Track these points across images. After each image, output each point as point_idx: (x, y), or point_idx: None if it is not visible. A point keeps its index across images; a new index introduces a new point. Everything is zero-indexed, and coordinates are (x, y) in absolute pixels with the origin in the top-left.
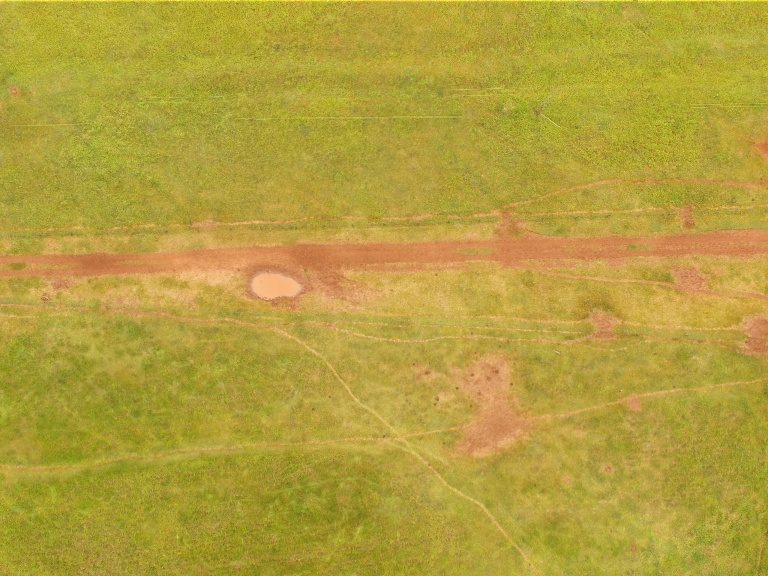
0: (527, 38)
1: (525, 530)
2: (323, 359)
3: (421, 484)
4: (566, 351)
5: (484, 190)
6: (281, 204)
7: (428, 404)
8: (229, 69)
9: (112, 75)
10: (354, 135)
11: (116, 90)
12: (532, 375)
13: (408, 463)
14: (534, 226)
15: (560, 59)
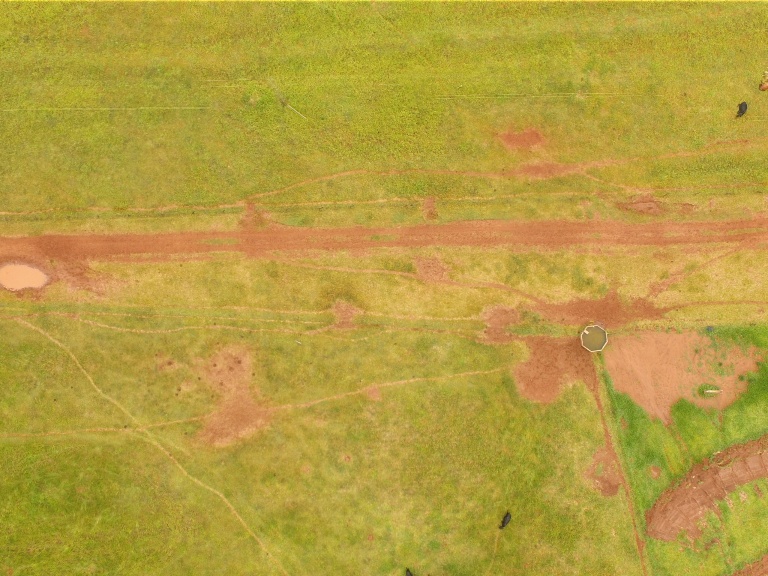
0: (276, 29)
1: (263, 520)
2: (66, 350)
3: (161, 474)
4: (308, 341)
5: (230, 181)
6: (28, 195)
7: (170, 394)
8: None
9: None
10: (101, 126)
11: None
12: (274, 365)
13: (149, 453)
14: (278, 217)
15: (307, 50)
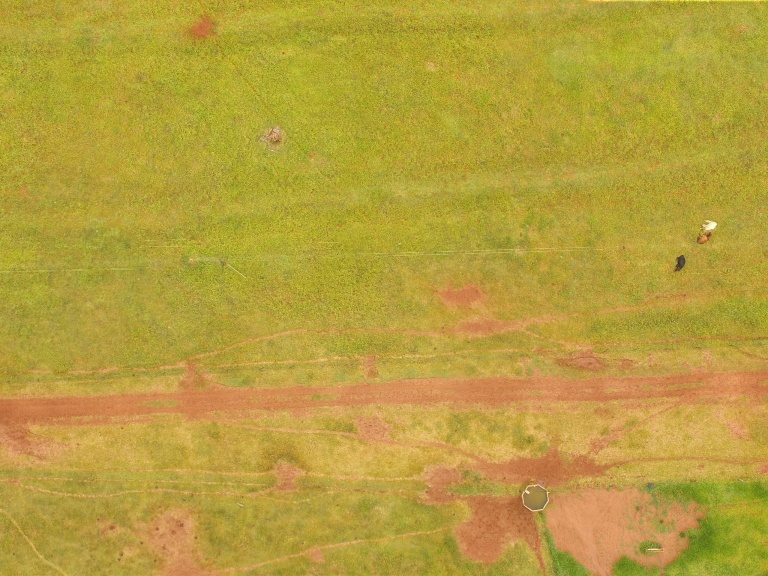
0: (215, 187)
1: None
2: (7, 516)
3: None
4: (250, 503)
5: (170, 342)
6: None
7: (112, 559)
8: None
9: None
10: (40, 289)
11: None
12: (216, 528)
13: None
14: (219, 378)
15: (246, 209)
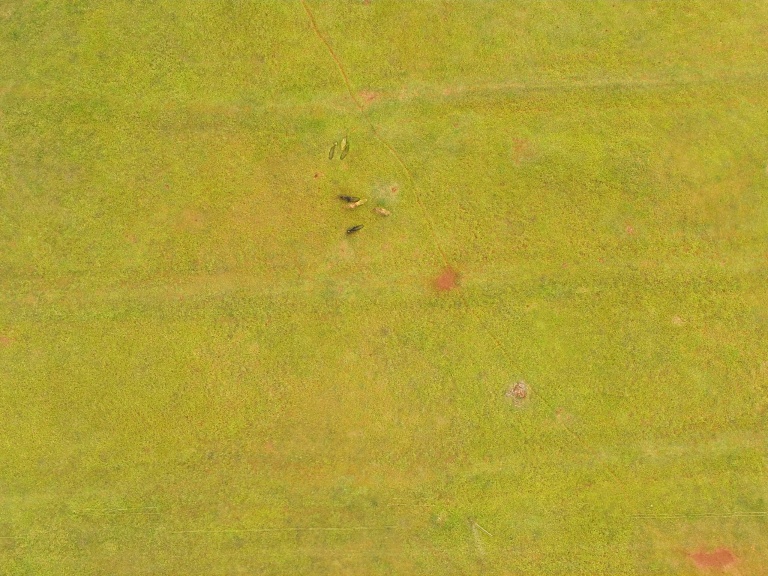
0: (461, 443)
1: None
2: None
3: None
4: None
5: None
6: None
7: None
8: (162, 481)
9: (45, 488)
10: (288, 547)
11: (49, 504)
12: None
13: None
14: None
15: (494, 467)
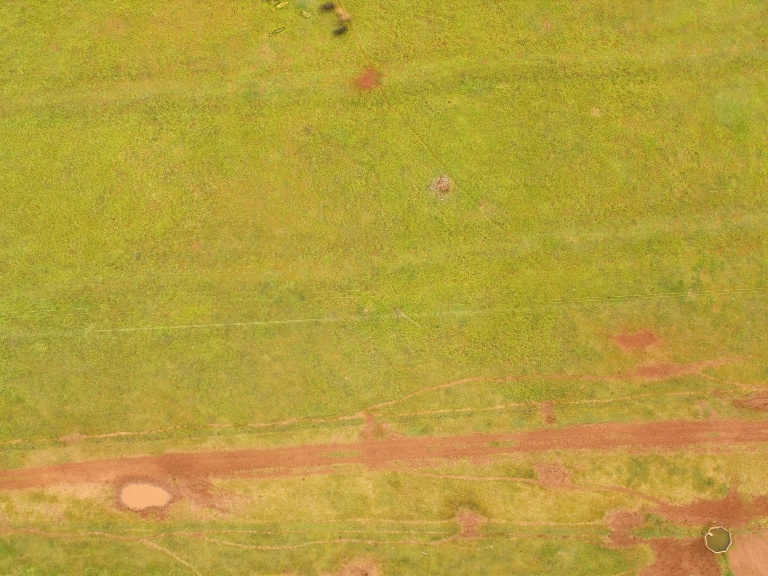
0: (386, 237)
1: None
2: (193, 569)
3: None
4: (433, 552)
5: (348, 392)
6: (147, 414)
7: None
8: (90, 281)
9: None
10: (217, 343)
11: None
12: None
13: None
14: (398, 427)
15: (419, 258)
